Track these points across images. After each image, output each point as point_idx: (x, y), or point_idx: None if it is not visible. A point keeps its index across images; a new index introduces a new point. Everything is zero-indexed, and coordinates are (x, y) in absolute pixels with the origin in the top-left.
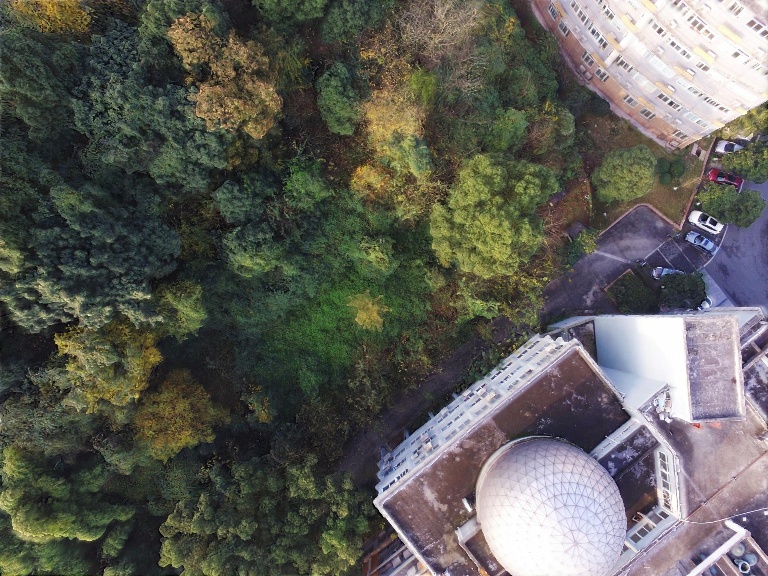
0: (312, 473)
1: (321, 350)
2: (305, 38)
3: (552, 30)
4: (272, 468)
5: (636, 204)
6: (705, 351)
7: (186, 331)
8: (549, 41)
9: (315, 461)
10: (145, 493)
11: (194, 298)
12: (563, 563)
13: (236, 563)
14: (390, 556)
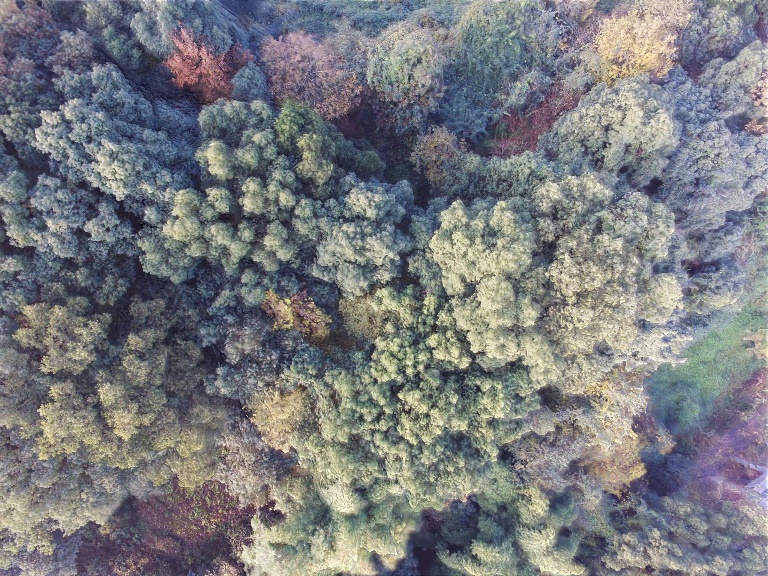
0: None
1: (698, 381)
2: None
3: None
4: (707, 503)
5: None
6: None
7: (649, 367)
8: None
9: None
10: None
11: None
12: None
13: None
14: None
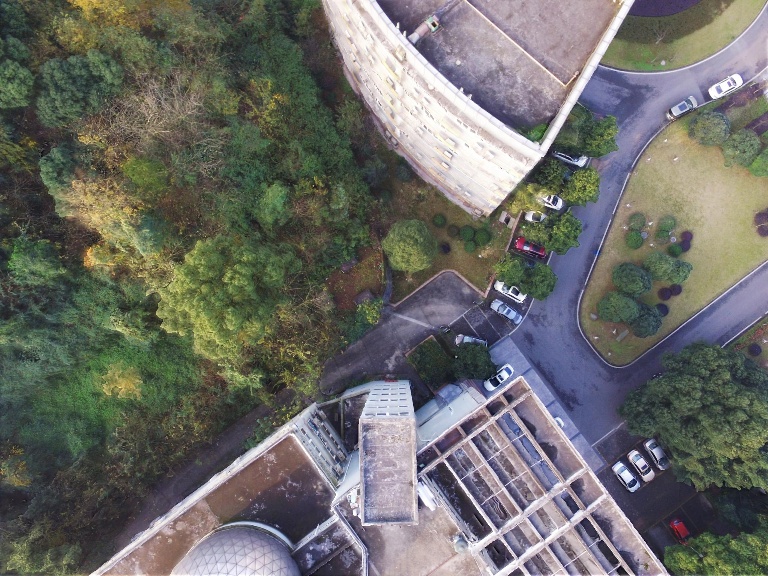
0: (31, 547)
1: (93, 413)
2: (15, 125)
3: (361, 94)
4: None
5: (441, 270)
6: (383, 453)
7: None
8: (347, 108)
9: (38, 534)
10: None
11: None
12: None
13: None
14: None
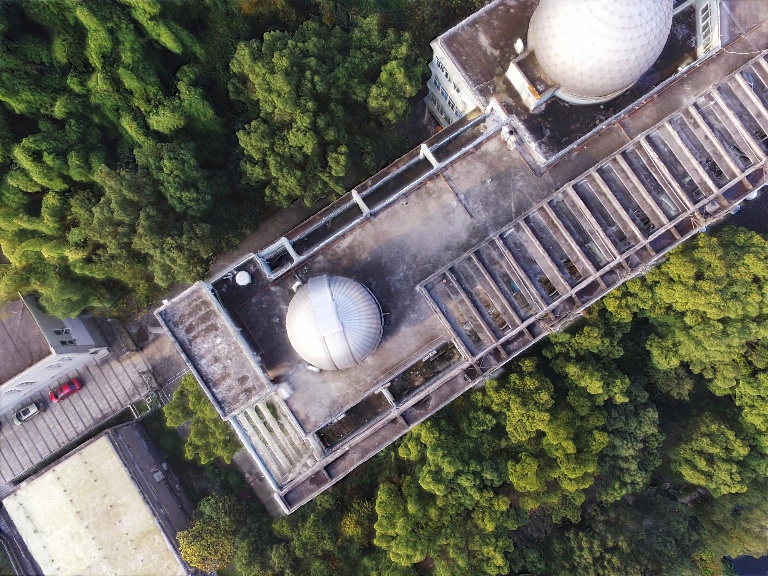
0: None
1: None
2: None
3: None
4: None
5: None
6: None
7: None
8: None
9: (378, 14)
10: (213, 62)
11: None
12: (616, 1)
13: (302, 73)
14: None
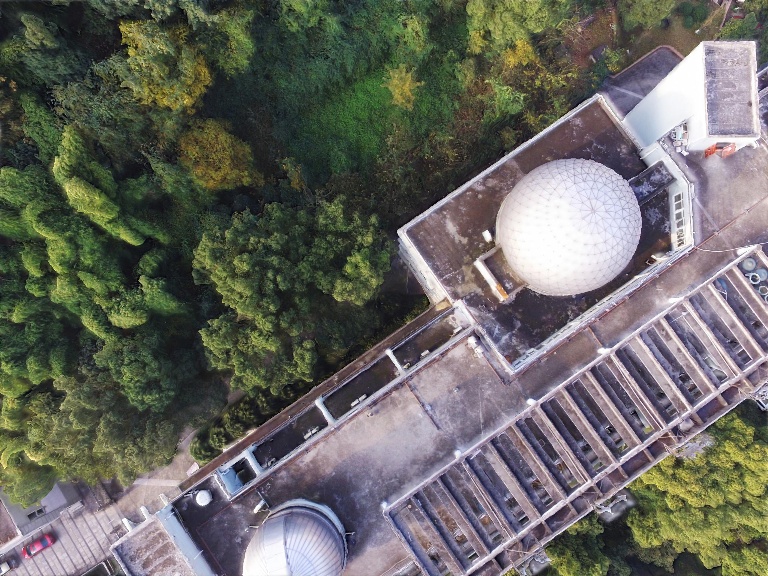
0: None
1: (352, 136)
2: None
3: None
4: None
5: (658, 45)
6: (723, 75)
7: (234, 64)
8: None
9: (344, 197)
10: (180, 236)
11: (246, 20)
12: (580, 230)
13: (265, 270)
14: None
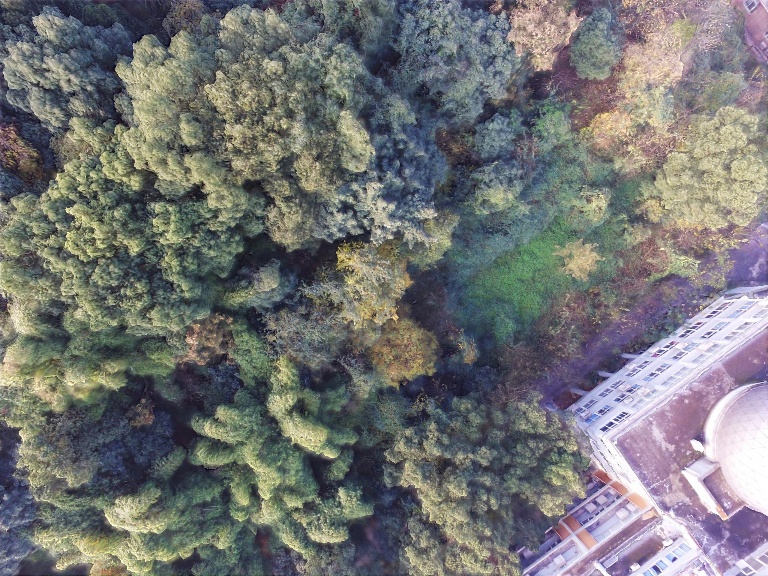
0: None
1: (516, 299)
2: None
3: None
4: (493, 403)
5: None
6: None
7: (429, 261)
8: (739, 15)
9: None
10: (357, 423)
11: (453, 226)
12: None
13: (474, 488)
14: (582, 502)
